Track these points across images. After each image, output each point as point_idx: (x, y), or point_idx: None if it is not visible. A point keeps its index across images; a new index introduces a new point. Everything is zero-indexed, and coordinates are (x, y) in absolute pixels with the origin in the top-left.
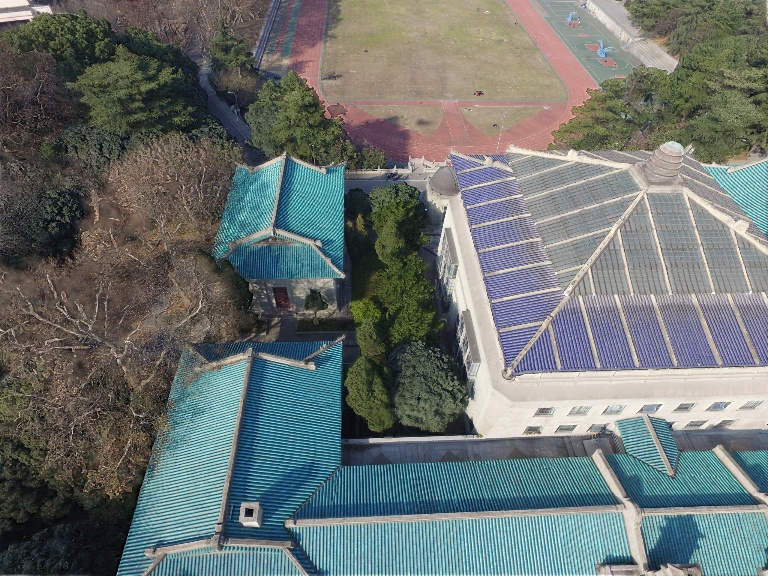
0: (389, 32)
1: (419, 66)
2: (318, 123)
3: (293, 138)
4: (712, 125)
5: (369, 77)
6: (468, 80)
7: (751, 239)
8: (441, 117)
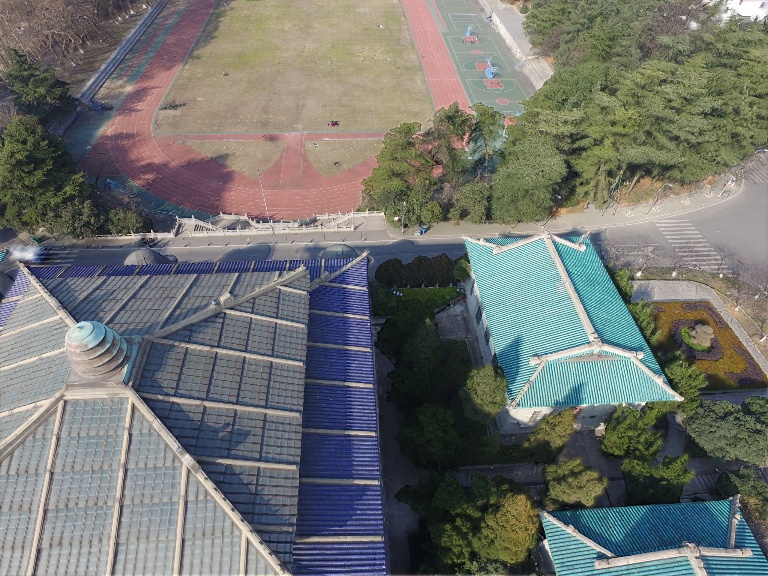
0: (262, 51)
1: (279, 91)
2: (37, 184)
3: (6, 203)
4: (511, 182)
5: (216, 106)
6: (328, 108)
7: (206, 486)
8: (278, 154)
